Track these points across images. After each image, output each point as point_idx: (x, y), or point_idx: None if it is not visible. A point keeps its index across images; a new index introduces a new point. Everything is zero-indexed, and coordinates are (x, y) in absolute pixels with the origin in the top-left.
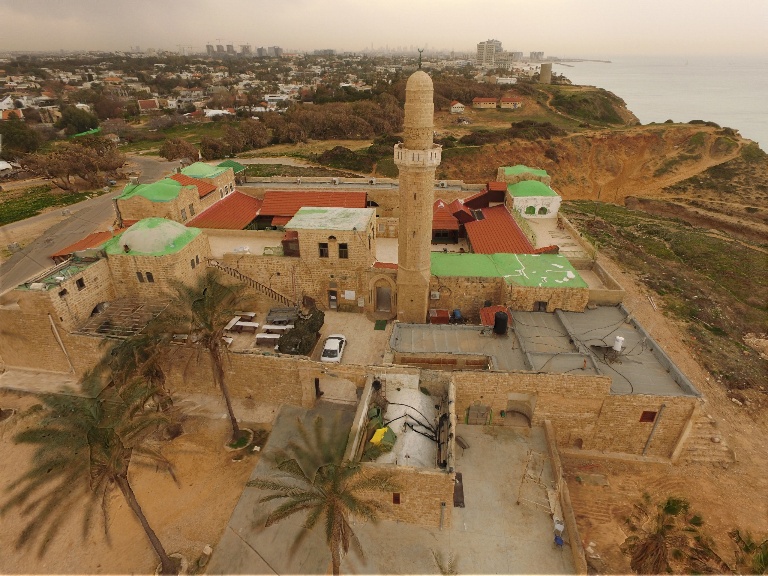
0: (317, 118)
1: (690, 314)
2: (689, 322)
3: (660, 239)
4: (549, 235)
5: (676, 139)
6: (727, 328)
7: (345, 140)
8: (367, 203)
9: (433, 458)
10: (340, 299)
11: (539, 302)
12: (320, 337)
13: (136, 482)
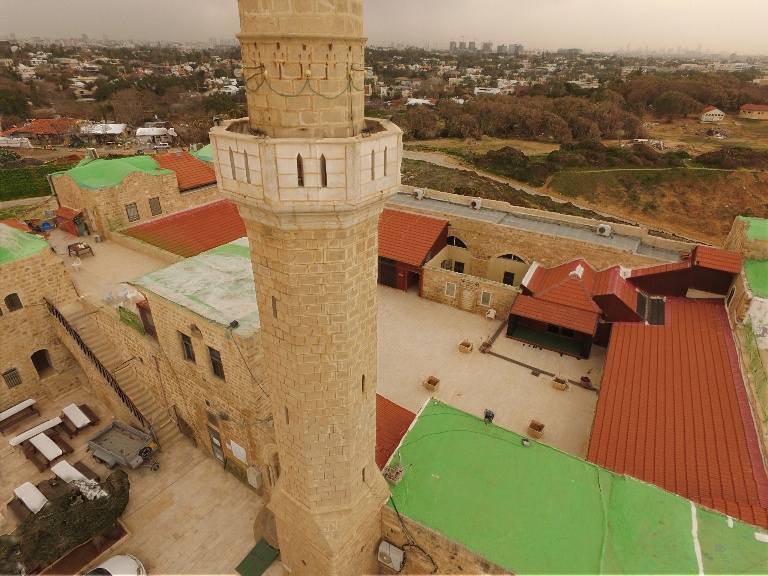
0: (501, 111)
1: None
2: None
3: None
4: None
5: None
6: None
7: (530, 141)
8: (448, 239)
9: None
10: (226, 450)
11: None
12: (116, 542)
13: None
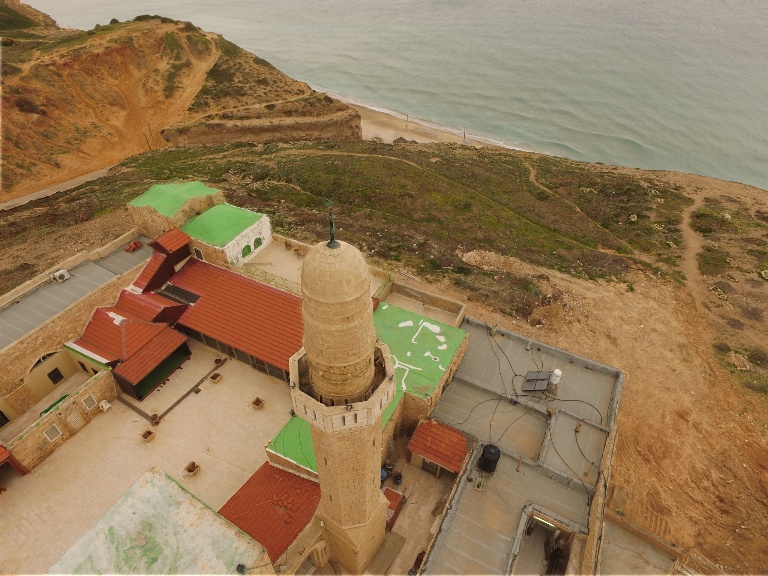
0: None
1: (436, 267)
2: (445, 276)
3: (281, 182)
4: None
5: (152, 46)
6: None
7: None
8: None
9: None
10: None
11: (444, 384)
12: None
13: None
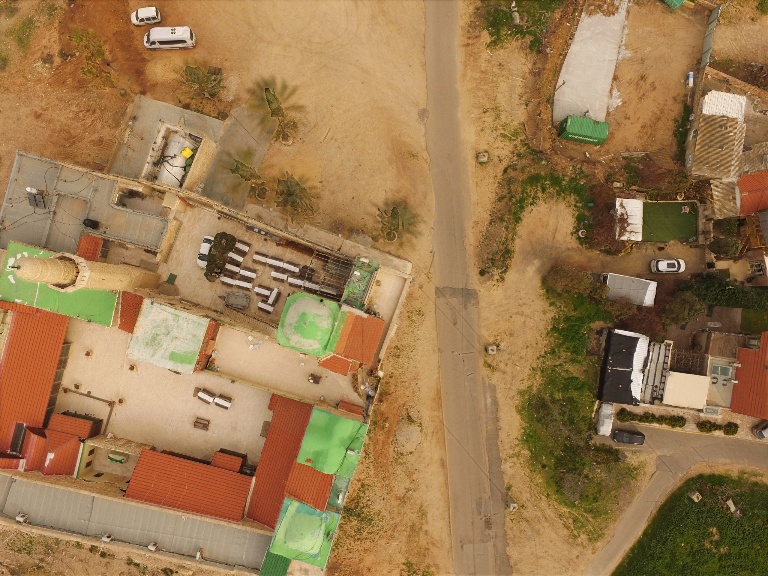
0: None
1: None
2: None
3: None
4: None
5: None
6: None
7: None
8: None
9: None
10: None
11: None
12: None
13: (310, 183)
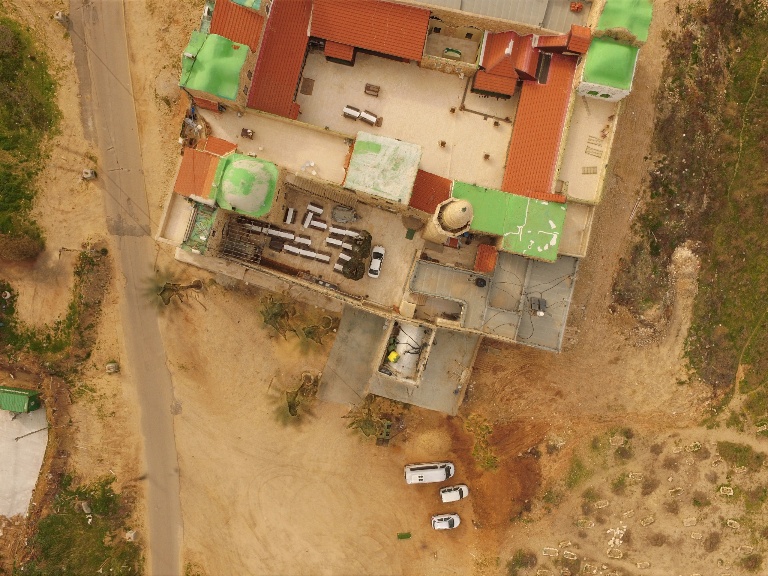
0: None
1: (652, 228)
2: (643, 238)
3: None
4: (585, 146)
5: None
6: (672, 239)
7: None
8: (430, 17)
9: (415, 362)
10: None
11: None
12: None
13: None
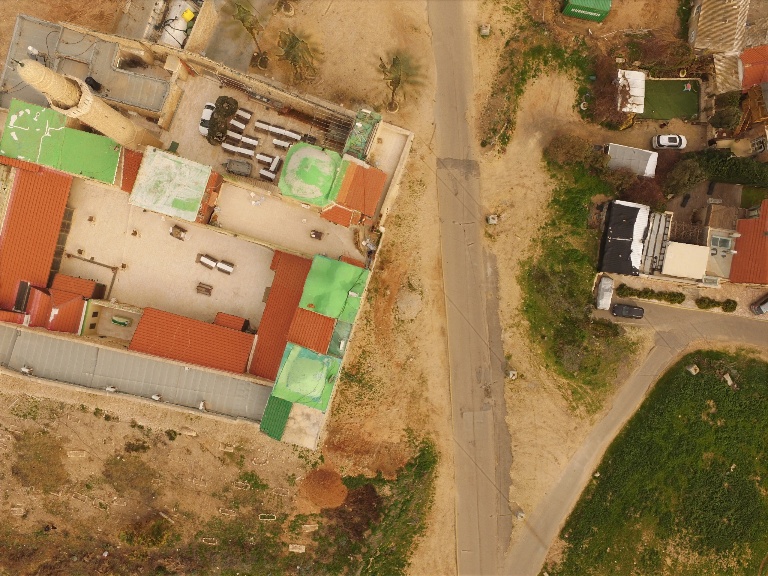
0: None
1: None
2: None
3: None
4: None
5: None
6: None
7: None
8: None
9: None
10: None
11: None
12: None
13: (312, 54)
